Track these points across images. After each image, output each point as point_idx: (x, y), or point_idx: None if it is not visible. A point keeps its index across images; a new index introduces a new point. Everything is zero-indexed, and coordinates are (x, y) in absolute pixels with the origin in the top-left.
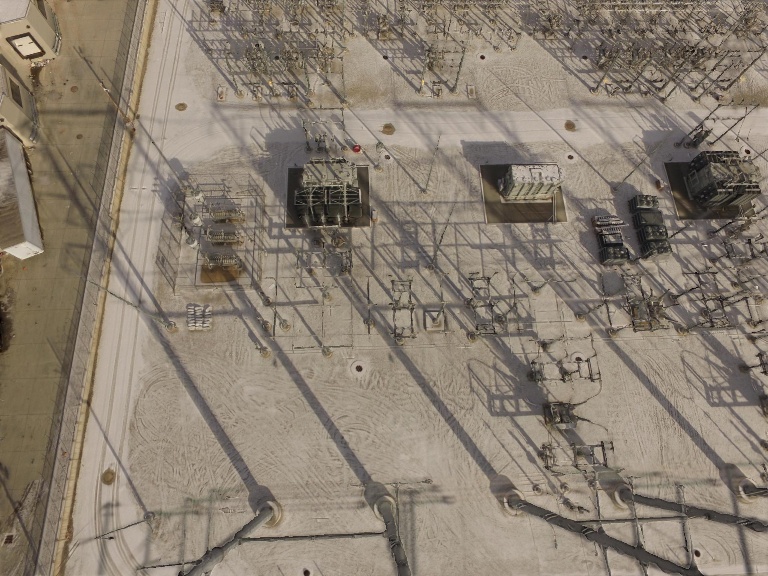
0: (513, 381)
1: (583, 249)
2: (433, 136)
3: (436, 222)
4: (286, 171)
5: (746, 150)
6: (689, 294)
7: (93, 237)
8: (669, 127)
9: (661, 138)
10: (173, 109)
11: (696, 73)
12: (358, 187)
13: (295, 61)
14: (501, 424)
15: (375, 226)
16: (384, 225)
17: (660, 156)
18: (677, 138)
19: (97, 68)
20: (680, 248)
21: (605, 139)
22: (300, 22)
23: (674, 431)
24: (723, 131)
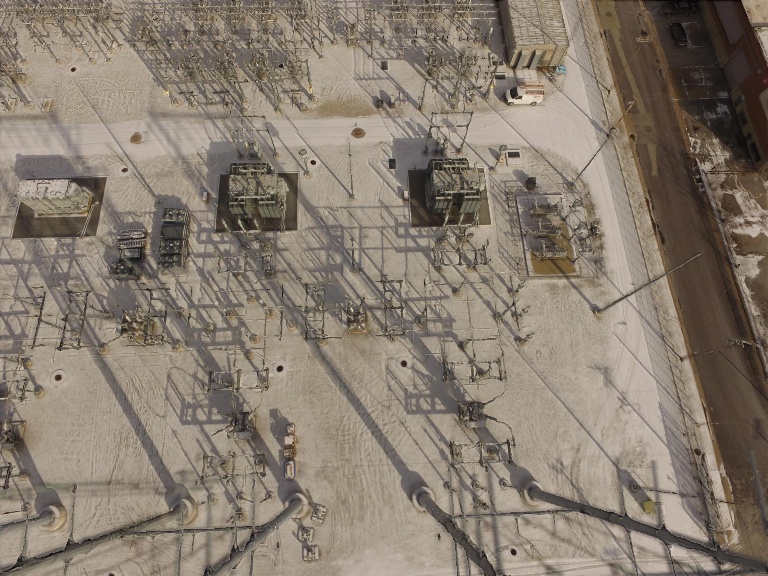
0: None
1: (104, 264)
2: None
3: None
4: None
5: (312, 161)
6: (199, 309)
7: None
8: (240, 138)
9: (227, 149)
10: None
11: (290, 83)
12: None
13: None
14: None
15: None
16: None
17: (219, 168)
18: (244, 149)
19: None
20: (207, 262)
21: (168, 151)
22: None
23: (134, 450)
24: (295, 142)
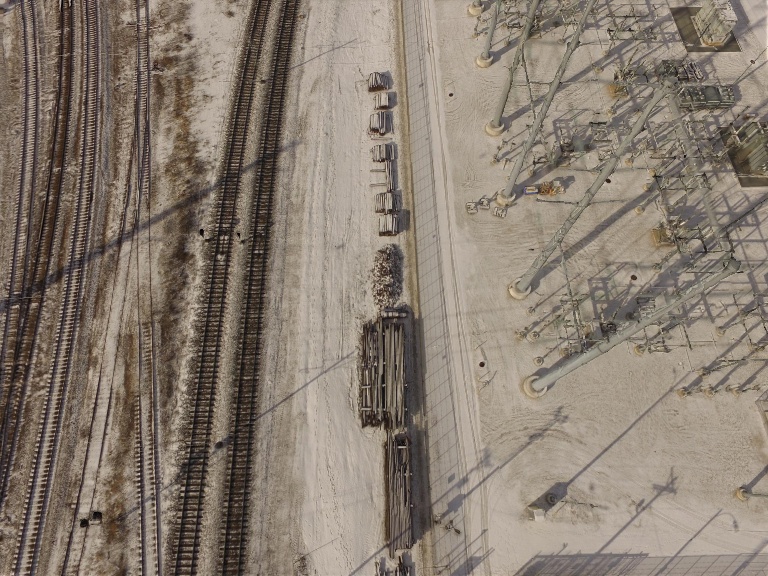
0: (551, 15)
1: None
2: None
3: None
4: None
5: None
6: None
7: None
8: None
9: None
10: None
11: None
12: None
13: None
14: (522, 8)
15: None
16: None
17: None
18: None
19: None
20: None
21: None
22: None
23: None
24: None
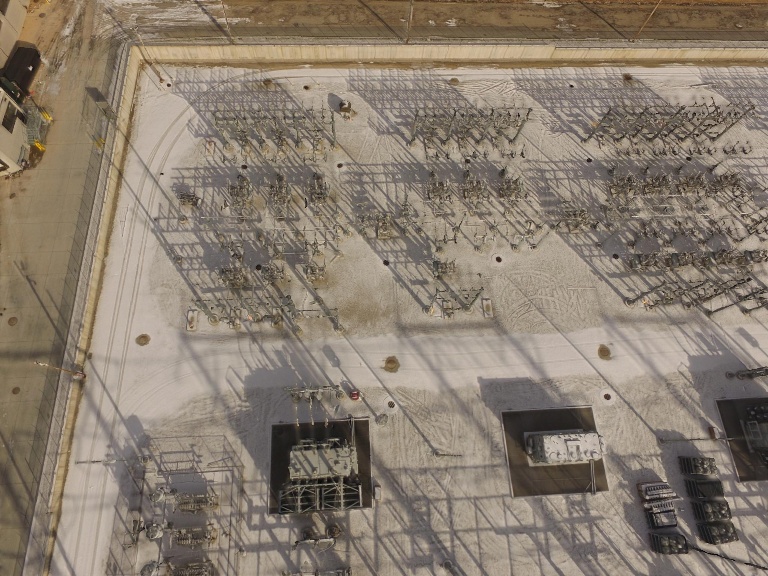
0: None
1: (629, 529)
2: (445, 372)
3: (452, 497)
4: (269, 429)
5: None
6: None
7: (26, 543)
8: (718, 350)
9: (710, 366)
10: (133, 344)
11: None
12: (358, 480)
13: (280, 272)
14: None
15: (378, 506)
16: (389, 504)
17: (711, 391)
18: (728, 365)
19: (42, 291)
20: (744, 522)
21: (646, 369)
22: (286, 216)
23: None
24: None
